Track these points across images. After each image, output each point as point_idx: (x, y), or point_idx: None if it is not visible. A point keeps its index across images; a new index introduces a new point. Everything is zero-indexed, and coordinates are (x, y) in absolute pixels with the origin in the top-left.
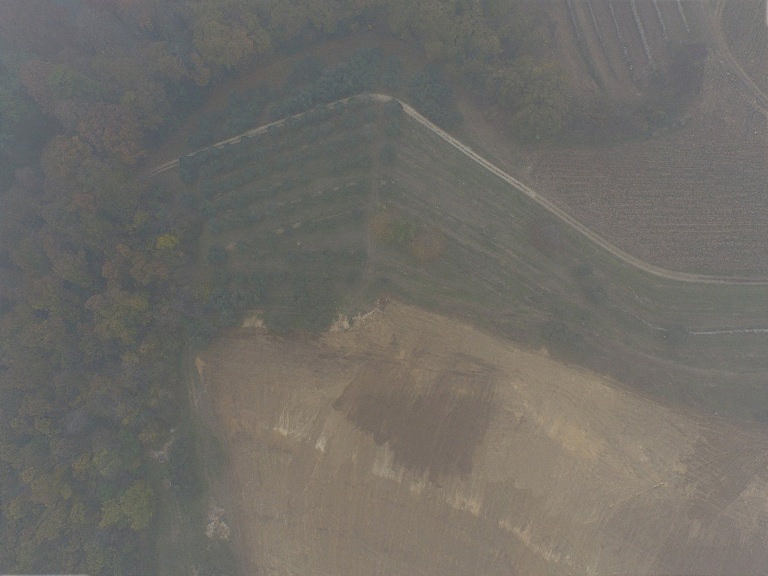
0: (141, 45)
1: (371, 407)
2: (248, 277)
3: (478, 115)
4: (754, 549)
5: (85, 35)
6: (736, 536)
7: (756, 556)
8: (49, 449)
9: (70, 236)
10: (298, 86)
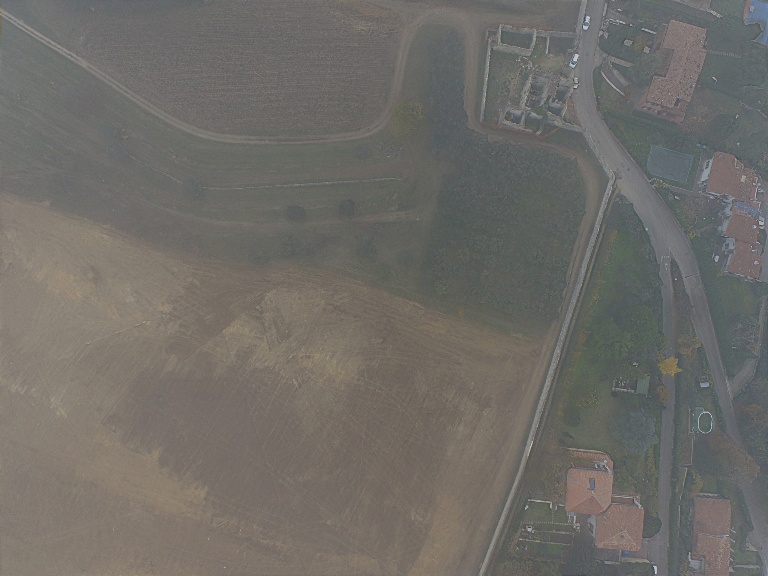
0: None
1: None
2: None
3: None
4: (228, 381)
5: None
6: (212, 369)
7: (229, 387)
8: None
9: None
10: None
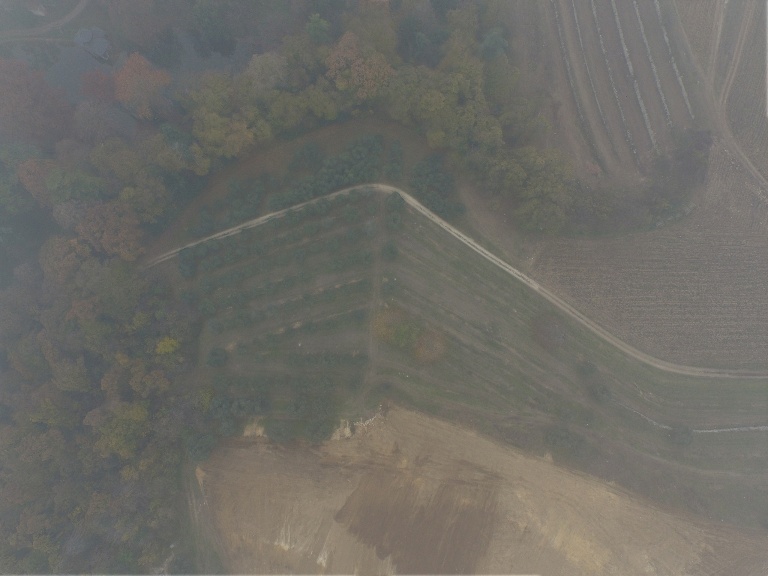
0: (140, 137)
1: (373, 519)
2: (249, 383)
3: (480, 203)
4: None
5: (84, 129)
6: None
7: None
8: (48, 564)
9: (69, 344)
10: (299, 174)
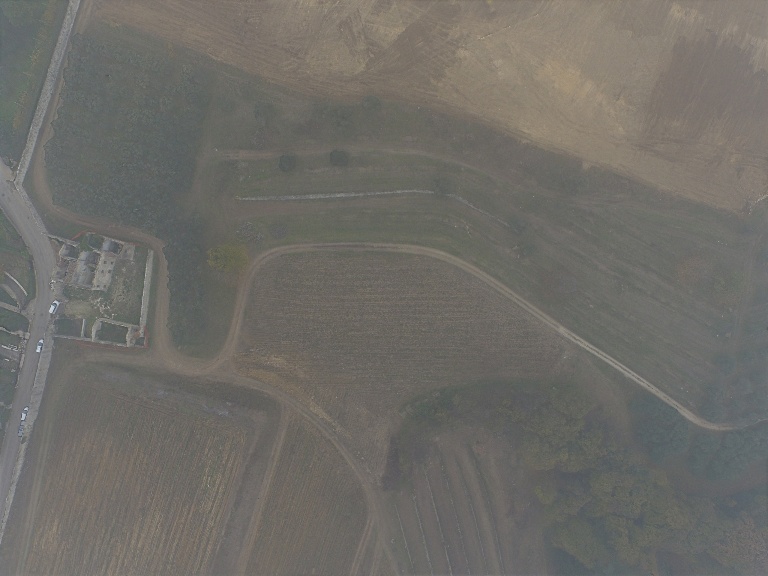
0: None
1: (767, 107)
2: None
3: None
4: None
5: None
6: None
7: None
8: None
9: None
10: None
